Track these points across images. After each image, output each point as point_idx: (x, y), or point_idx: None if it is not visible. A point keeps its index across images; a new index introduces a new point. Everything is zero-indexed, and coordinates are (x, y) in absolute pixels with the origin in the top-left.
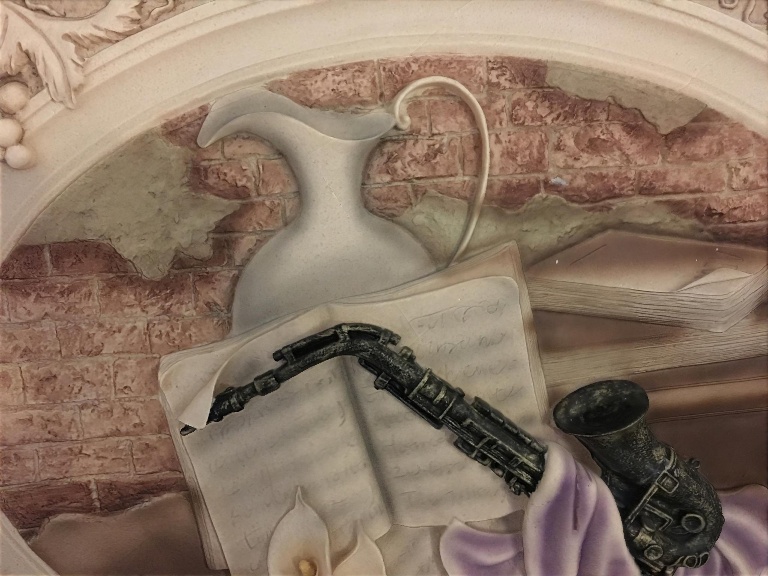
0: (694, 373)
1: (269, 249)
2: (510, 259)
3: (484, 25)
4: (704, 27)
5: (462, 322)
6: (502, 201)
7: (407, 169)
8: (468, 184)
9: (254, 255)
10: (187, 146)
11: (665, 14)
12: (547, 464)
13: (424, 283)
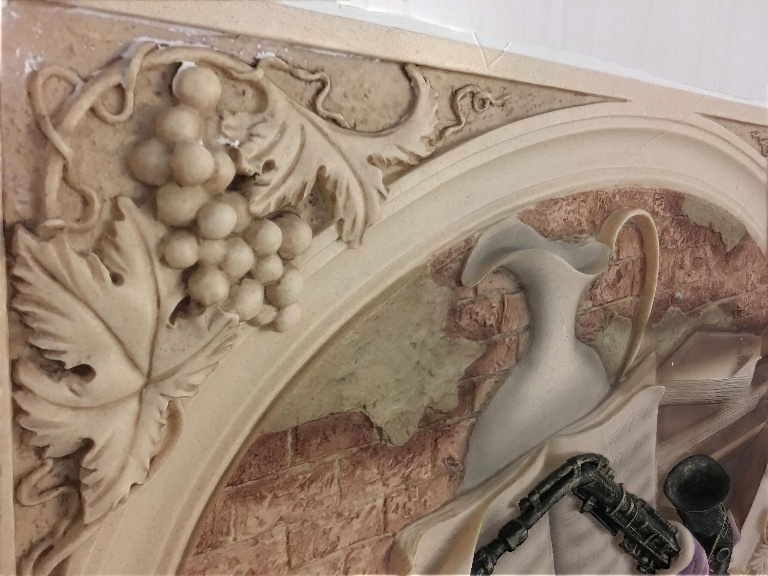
0: (721, 436)
1: (507, 390)
2: (654, 368)
3: (655, 160)
4: (757, 170)
5: (629, 432)
6: (650, 316)
7: (603, 294)
8: (634, 304)
9: (491, 398)
10: (448, 285)
11: (744, 159)
12: (683, 543)
13: (614, 402)
